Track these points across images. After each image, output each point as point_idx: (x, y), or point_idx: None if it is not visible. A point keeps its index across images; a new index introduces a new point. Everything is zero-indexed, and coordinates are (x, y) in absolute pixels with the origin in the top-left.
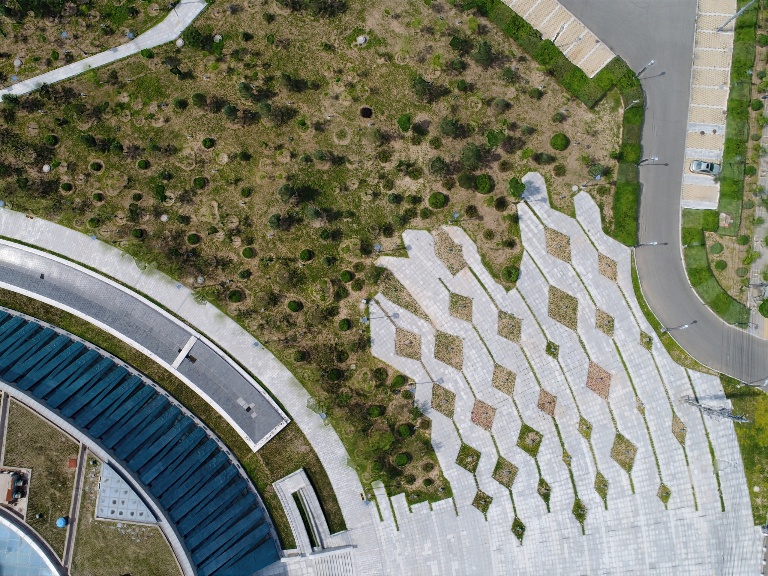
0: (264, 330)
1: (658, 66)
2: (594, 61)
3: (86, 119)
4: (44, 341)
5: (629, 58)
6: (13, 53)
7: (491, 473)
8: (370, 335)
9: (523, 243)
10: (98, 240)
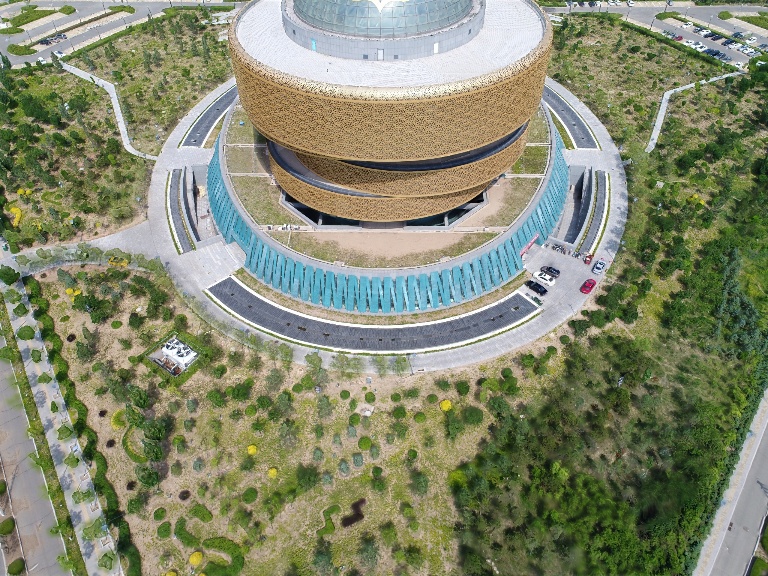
0: None
1: (168, 6)
2: None
3: None
4: None
5: None
6: None
7: None
8: None
9: None
10: (204, 98)
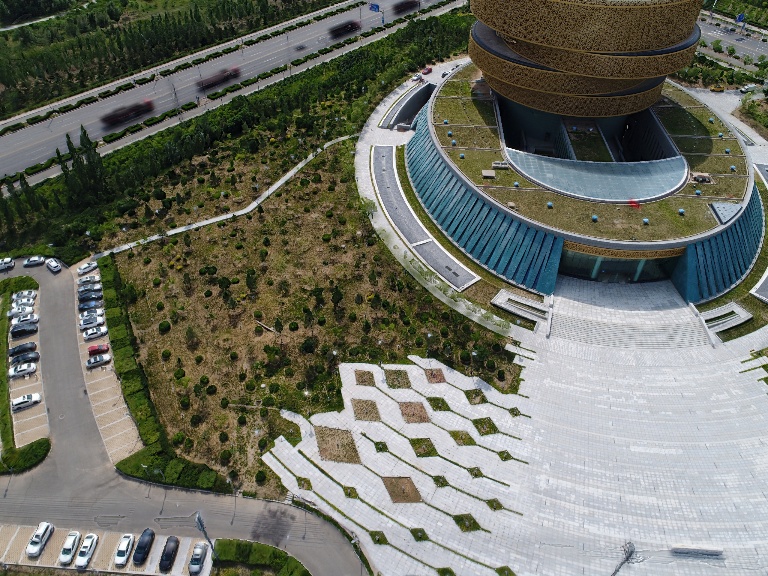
0: None
1: None
2: None
3: None
4: None
5: None
6: None
7: None
8: None
9: None
10: None
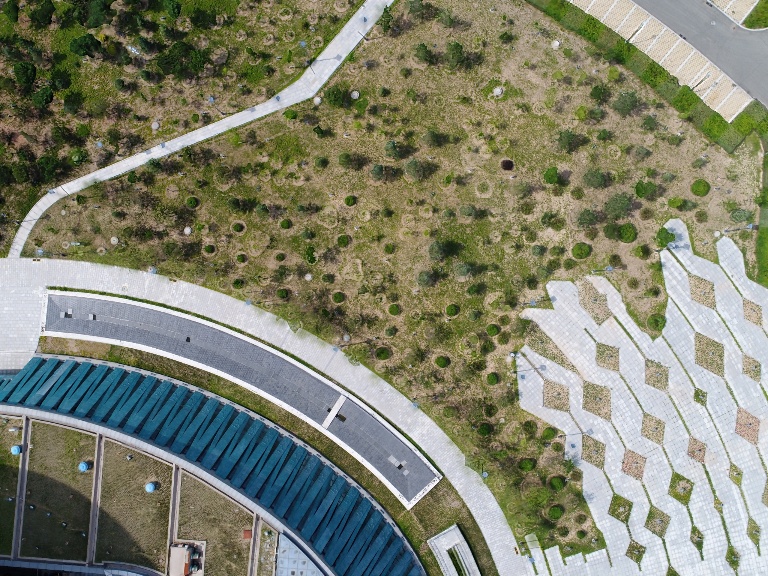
0: (412, 386)
1: None
2: (731, 105)
3: (226, 180)
4: (197, 406)
5: (766, 101)
6: (150, 116)
7: (643, 523)
8: (518, 388)
9: (667, 291)
10: (242, 301)
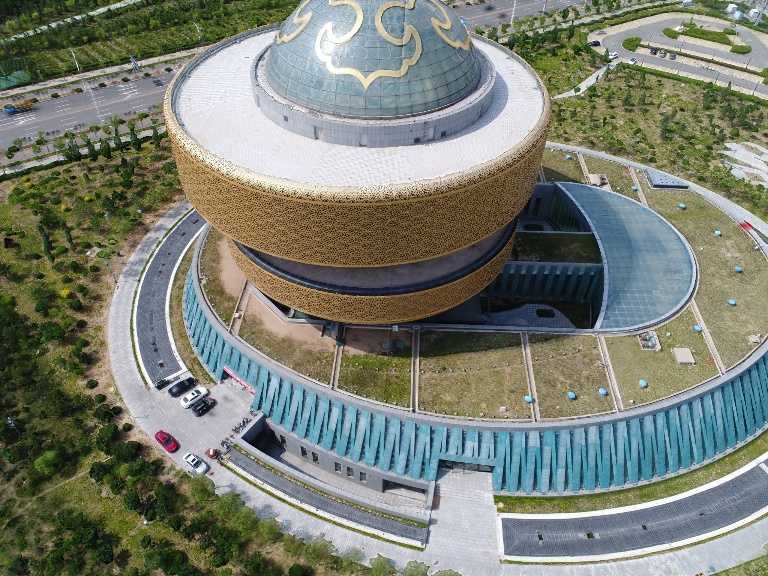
0: None
1: None
2: None
3: None
4: None
5: None
6: None
7: None
8: (732, 174)
9: None
10: (570, 145)
